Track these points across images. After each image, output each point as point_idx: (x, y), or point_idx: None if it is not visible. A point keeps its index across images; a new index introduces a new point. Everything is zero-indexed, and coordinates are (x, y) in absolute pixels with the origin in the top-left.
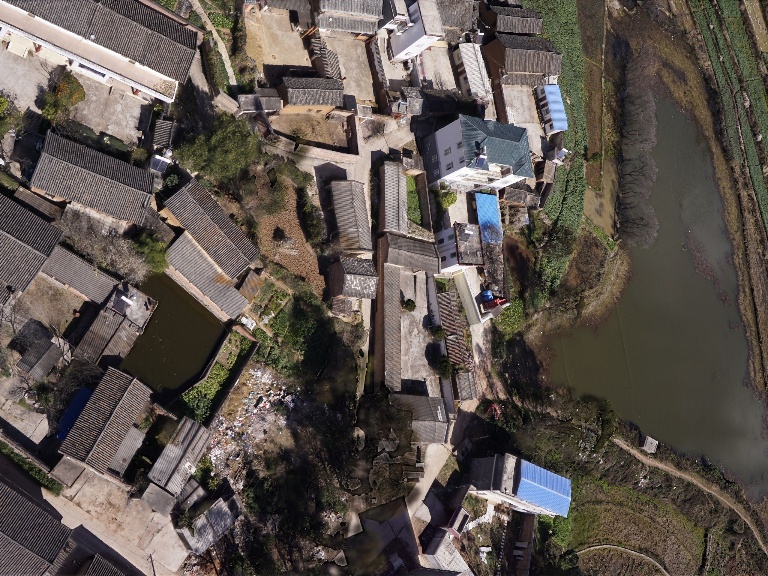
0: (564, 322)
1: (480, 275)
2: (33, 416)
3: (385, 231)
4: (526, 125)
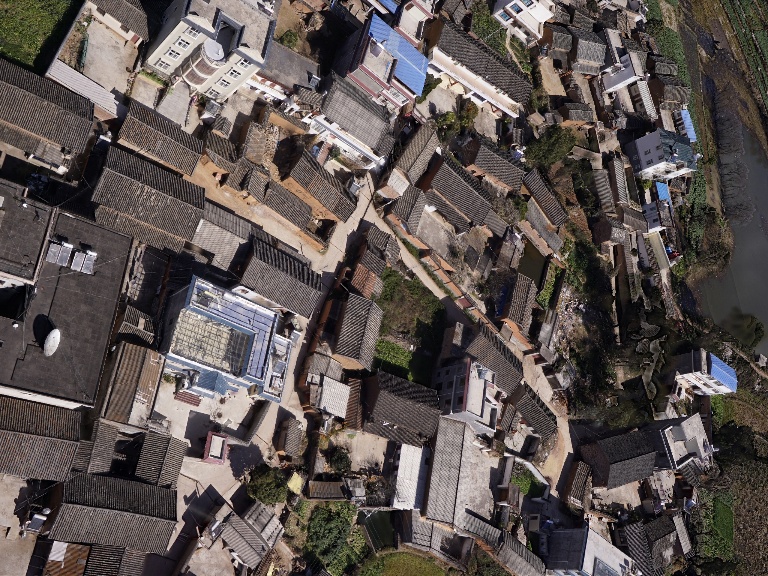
0: (704, 274)
1: (661, 237)
2: (479, 302)
3: (619, 203)
4: None
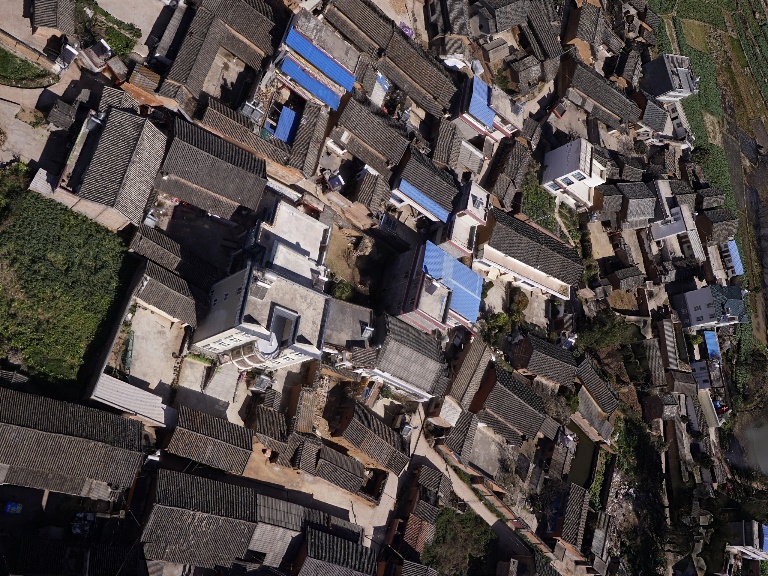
0: None
1: (709, 390)
2: (530, 516)
3: (669, 369)
4: (717, 272)
